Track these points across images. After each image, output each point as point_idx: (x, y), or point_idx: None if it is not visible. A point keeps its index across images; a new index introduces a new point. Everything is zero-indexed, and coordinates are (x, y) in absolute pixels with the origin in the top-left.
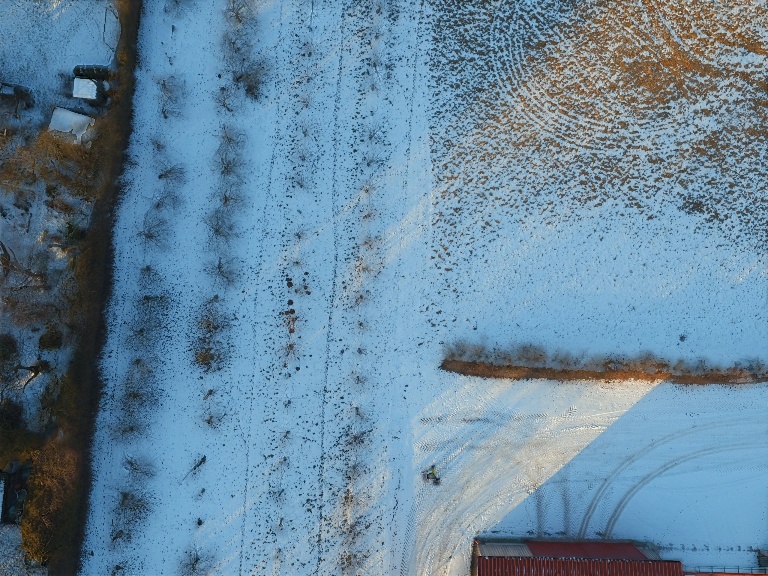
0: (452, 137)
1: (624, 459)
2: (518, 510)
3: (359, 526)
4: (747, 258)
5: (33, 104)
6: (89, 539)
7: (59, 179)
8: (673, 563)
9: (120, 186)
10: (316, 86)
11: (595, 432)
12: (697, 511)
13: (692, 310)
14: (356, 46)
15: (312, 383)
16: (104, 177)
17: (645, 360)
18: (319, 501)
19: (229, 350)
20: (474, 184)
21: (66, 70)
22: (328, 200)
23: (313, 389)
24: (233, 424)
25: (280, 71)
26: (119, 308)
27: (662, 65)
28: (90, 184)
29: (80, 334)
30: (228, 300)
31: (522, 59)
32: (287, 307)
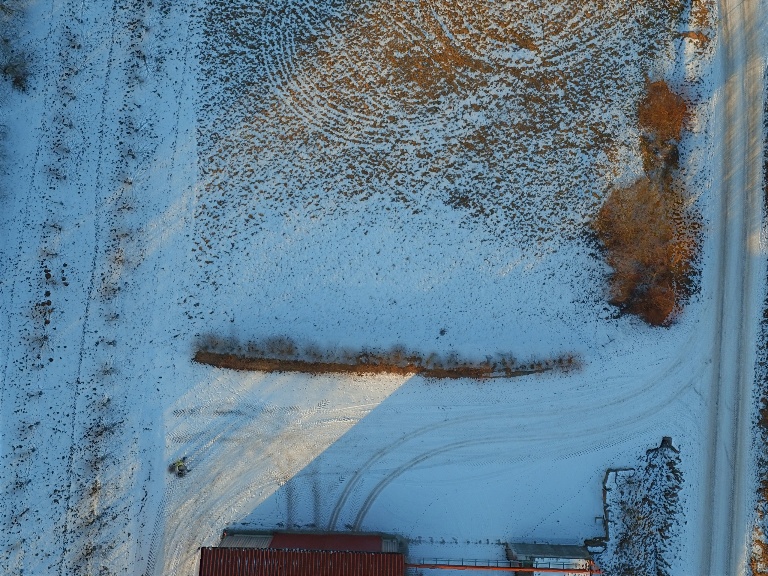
0: (219, 130)
1: (375, 452)
2: (268, 502)
3: (106, 517)
4: (511, 253)
5: None
6: None
7: None
8: (395, 555)
9: None
10: (85, 78)
11: (347, 425)
12: (446, 504)
13: (453, 304)
14: (126, 39)
15: (65, 374)
16: None
17: (398, 353)
18: (67, 492)
19: None
20: (239, 177)
21: None
22: (91, 192)
23: (66, 380)
24: None
25: (49, 63)
26: None
27: (433, 60)
28: None
29: None
30: None
31: (293, 53)
32: (44, 298)
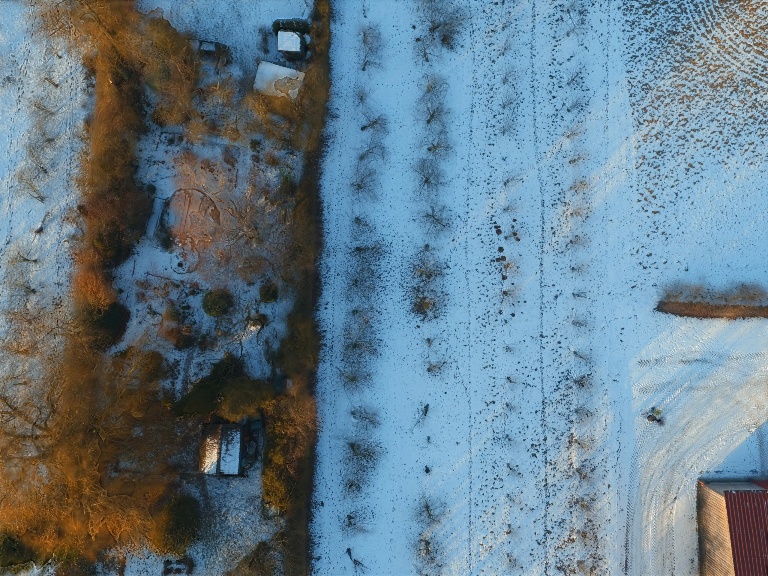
0: (650, 81)
1: None
2: (740, 449)
3: (585, 469)
4: None
5: (231, 60)
6: (318, 490)
7: (266, 133)
8: None
9: (323, 139)
10: (511, 34)
11: None
12: None
13: None
14: None
15: (528, 329)
16: (309, 130)
17: None
18: (543, 446)
19: (444, 298)
20: (675, 127)
21: (262, 26)
22: (531, 147)
23: (530, 335)
24: (453, 372)
25: (474, 20)
26: (331, 260)
27: None
28: (293, 138)
29: (295, 287)
30: (439, 249)
31: (715, 1)
32: (498, 254)
